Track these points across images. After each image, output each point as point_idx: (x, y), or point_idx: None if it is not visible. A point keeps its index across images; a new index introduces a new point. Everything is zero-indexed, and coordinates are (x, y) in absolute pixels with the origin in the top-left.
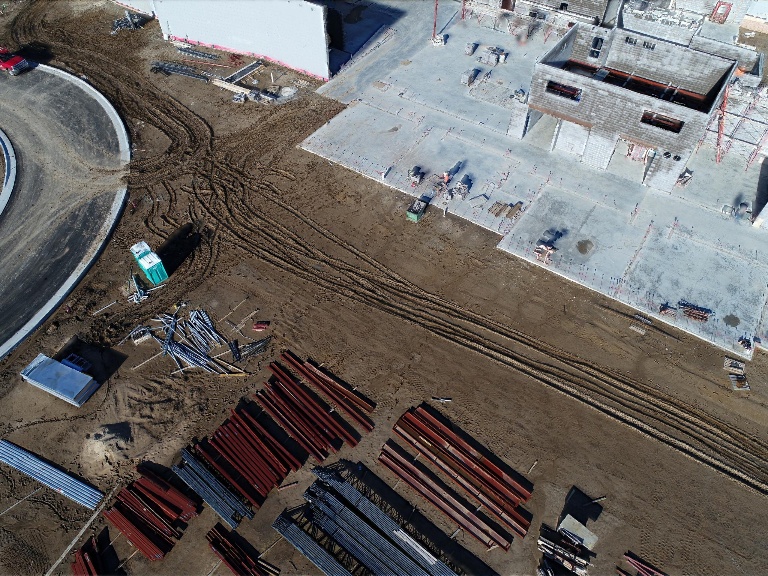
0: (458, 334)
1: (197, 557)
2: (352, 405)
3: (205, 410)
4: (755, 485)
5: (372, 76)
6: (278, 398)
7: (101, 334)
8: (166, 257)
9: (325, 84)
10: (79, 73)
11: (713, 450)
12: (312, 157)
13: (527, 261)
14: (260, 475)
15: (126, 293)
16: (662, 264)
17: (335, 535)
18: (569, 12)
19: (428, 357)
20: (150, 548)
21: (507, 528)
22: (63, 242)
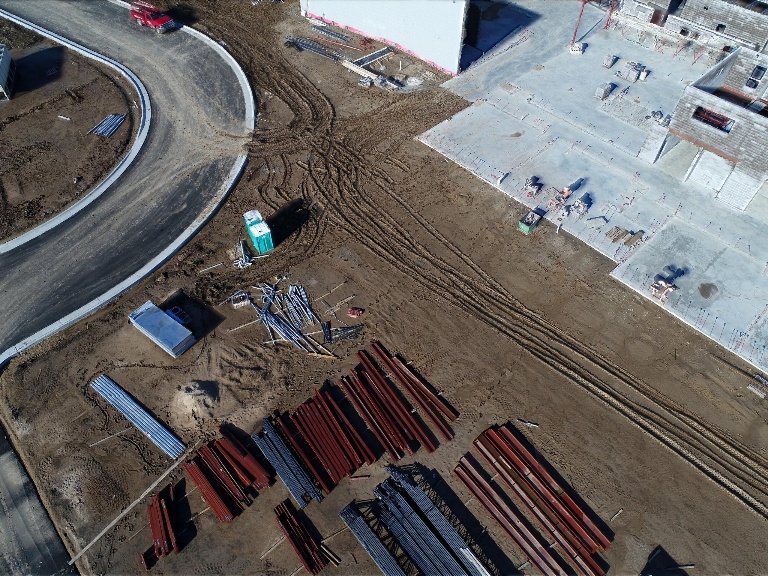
0: (555, 358)
1: (263, 528)
2: (435, 410)
3: (290, 385)
4: None
5: (501, 77)
6: (362, 388)
7: (204, 292)
8: (274, 228)
9: (452, 79)
10: (218, 38)
11: None
12: (429, 151)
13: (641, 295)
14: (334, 461)
15: (232, 257)
16: None
17: (400, 538)
18: (727, 35)
19: (520, 376)
20: (221, 508)
21: (580, 573)
22: (182, 198)
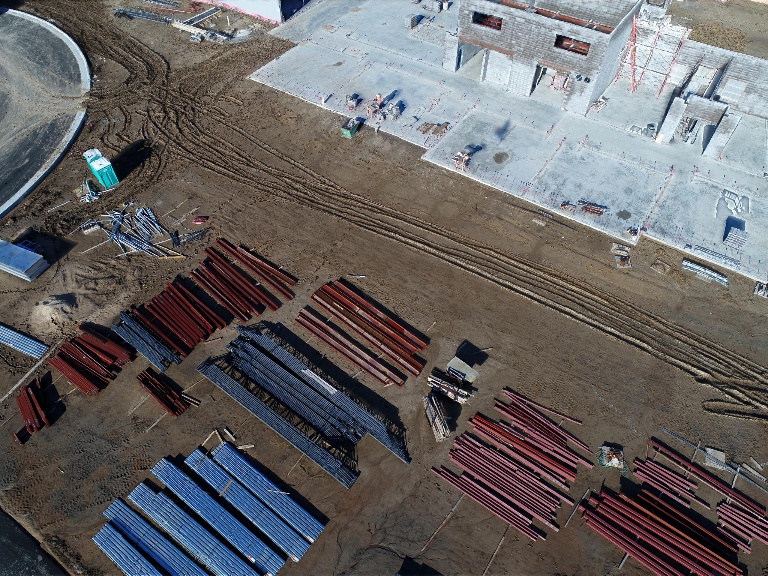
0: (378, 226)
1: (128, 392)
2: (277, 280)
3: (144, 284)
4: (624, 338)
5: (323, 20)
6: (210, 274)
7: (54, 226)
8: (118, 166)
9: (278, 27)
10: (47, 17)
11: (592, 312)
12: (260, 86)
13: (447, 169)
14: (189, 331)
15: (79, 194)
16: (569, 171)
17: (250, 373)
18: None
19: (349, 244)
20: (87, 385)
21: (403, 370)
22: (24, 154)
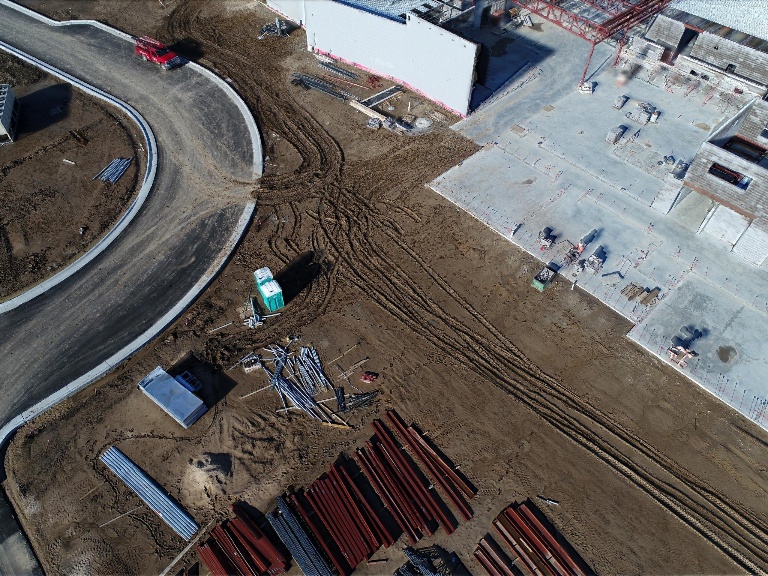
0: (573, 428)
1: None
2: (452, 486)
3: (304, 458)
4: None
5: (511, 118)
6: (378, 462)
7: (215, 354)
8: (285, 284)
9: (462, 121)
10: (225, 75)
11: None
12: (440, 199)
13: (659, 358)
14: (351, 544)
15: (243, 315)
16: None
17: None
18: (738, 77)
19: (538, 448)
20: None
21: None
22: (190, 250)
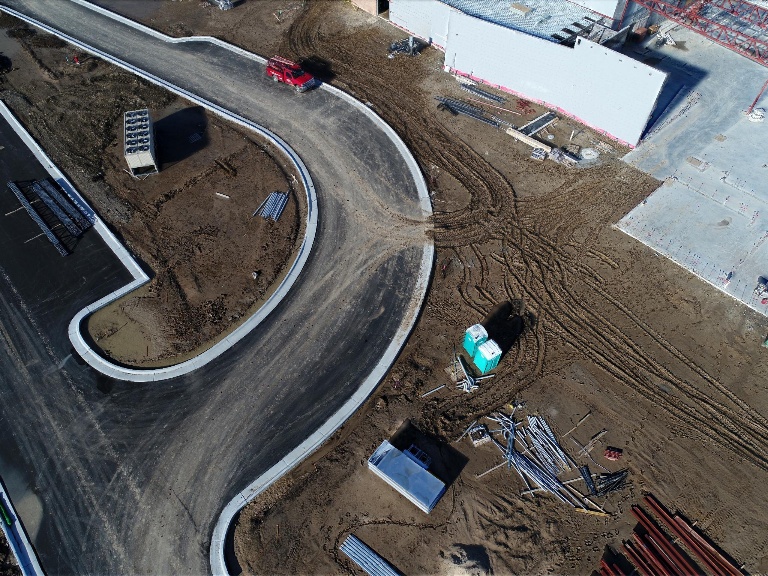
0: None
1: None
2: None
3: (567, 552)
4: None
5: (684, 149)
6: (655, 559)
7: (435, 423)
8: None
9: (631, 152)
10: (364, 99)
11: None
12: (633, 242)
13: None
14: None
15: (454, 377)
16: None
17: None
18: None
19: None
20: None
21: None
22: (377, 299)
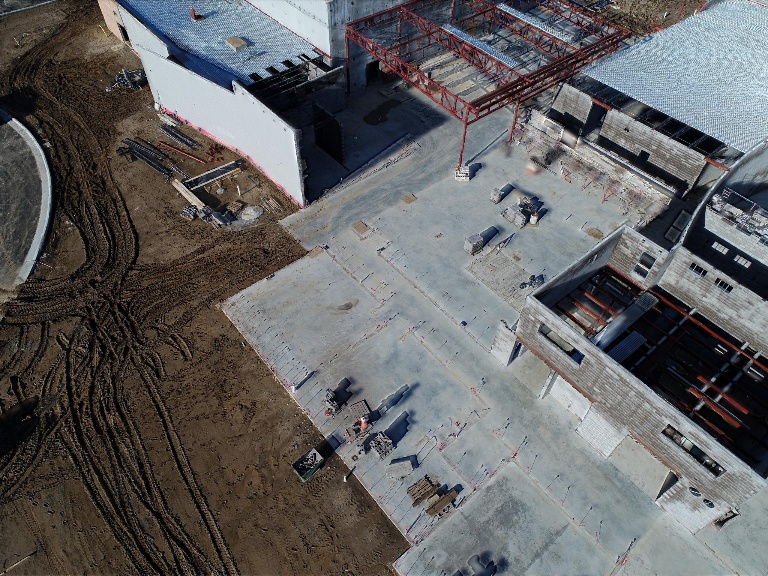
0: None
1: None
2: None
3: None
4: None
5: (358, 212)
6: None
7: None
8: None
9: (297, 212)
10: (45, 138)
11: None
12: (227, 327)
13: None
14: None
15: None
16: None
17: None
18: (644, 172)
19: None
20: None
21: None
22: None
